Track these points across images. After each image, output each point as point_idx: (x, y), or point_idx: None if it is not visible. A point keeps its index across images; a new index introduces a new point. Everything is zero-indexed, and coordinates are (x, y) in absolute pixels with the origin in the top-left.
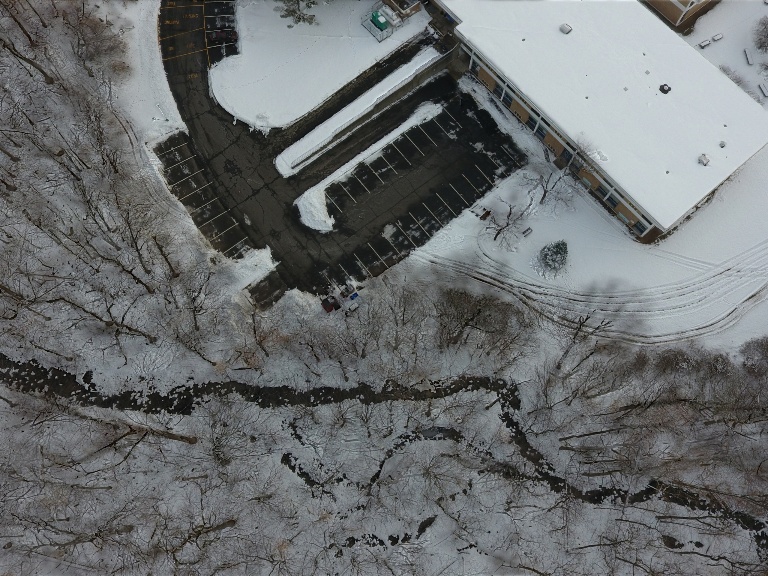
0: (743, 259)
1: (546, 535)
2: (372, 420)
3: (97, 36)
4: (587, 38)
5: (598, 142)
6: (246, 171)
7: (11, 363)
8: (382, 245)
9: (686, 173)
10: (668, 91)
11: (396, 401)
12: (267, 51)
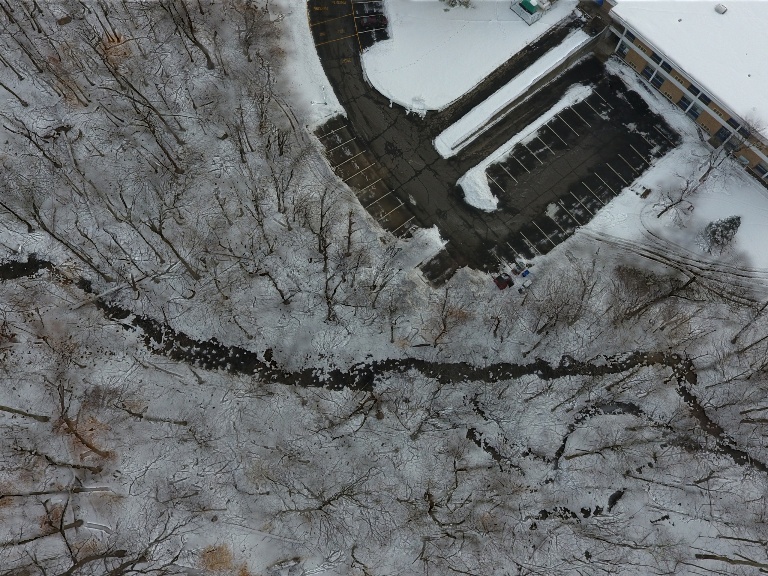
0: None
1: (741, 506)
2: (554, 395)
3: (258, 21)
4: (743, 18)
5: (766, 118)
6: (407, 152)
7: (191, 342)
8: (547, 223)
9: None
10: None
11: (574, 376)
12: (417, 36)
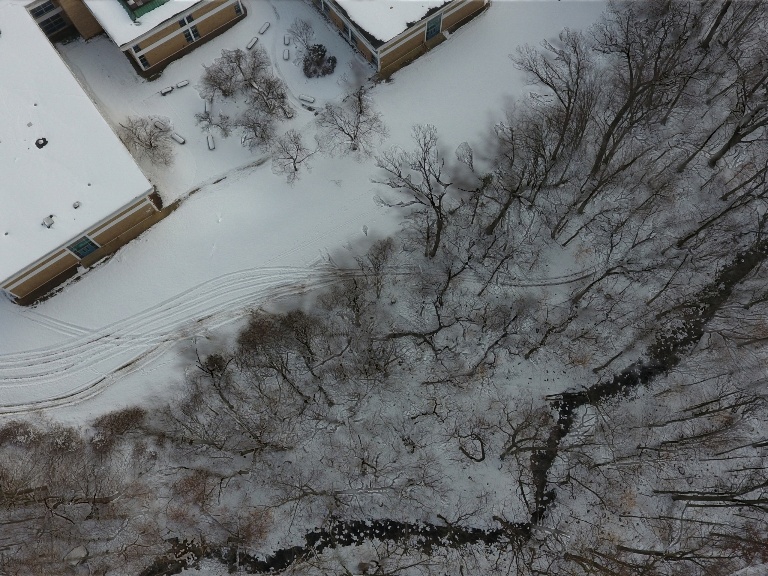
0: (126, 325)
1: None
2: None
3: None
4: None
5: None
6: None
7: None
8: None
9: (25, 235)
10: (43, 145)
11: None
12: None
